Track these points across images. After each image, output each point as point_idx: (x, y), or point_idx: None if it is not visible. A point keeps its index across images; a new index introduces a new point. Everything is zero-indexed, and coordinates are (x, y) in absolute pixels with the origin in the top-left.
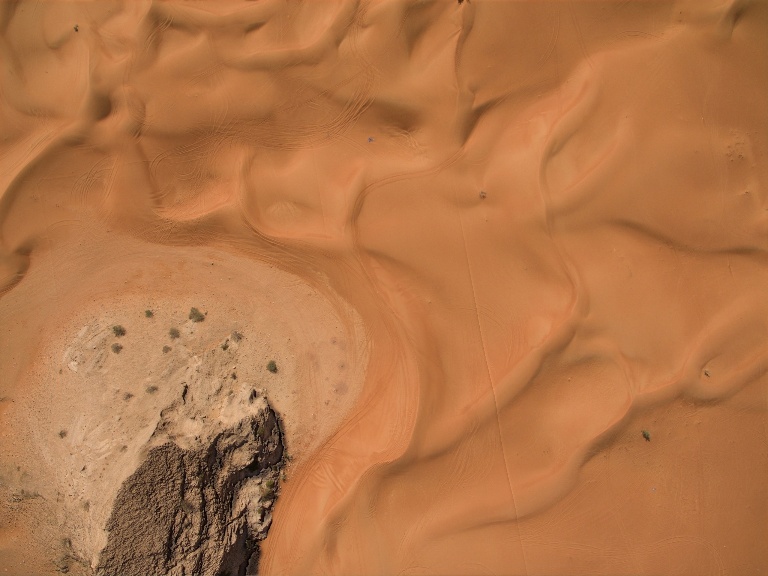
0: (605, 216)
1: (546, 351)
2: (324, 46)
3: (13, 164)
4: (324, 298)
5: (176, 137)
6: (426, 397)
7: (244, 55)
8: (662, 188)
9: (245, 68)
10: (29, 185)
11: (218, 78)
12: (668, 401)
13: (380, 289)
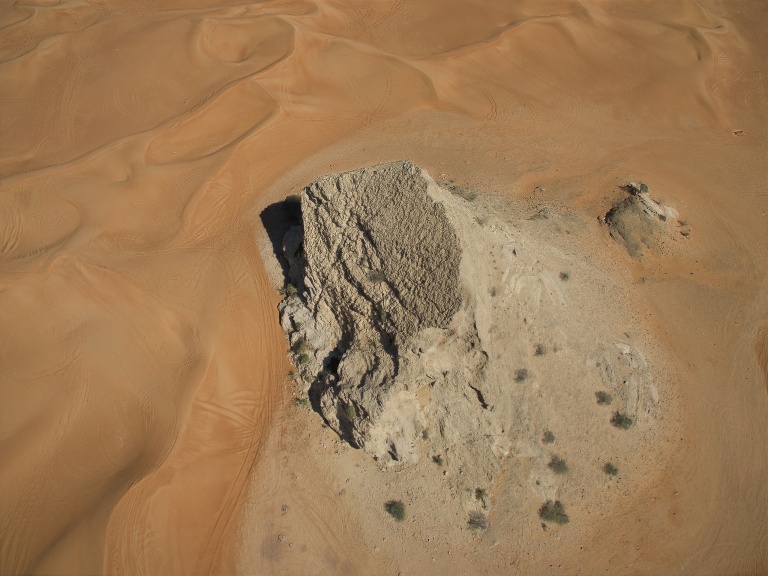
0: None
1: None
2: None
3: None
4: None
5: None
6: None
7: None
8: None
9: None
10: None
11: None
12: None
13: None
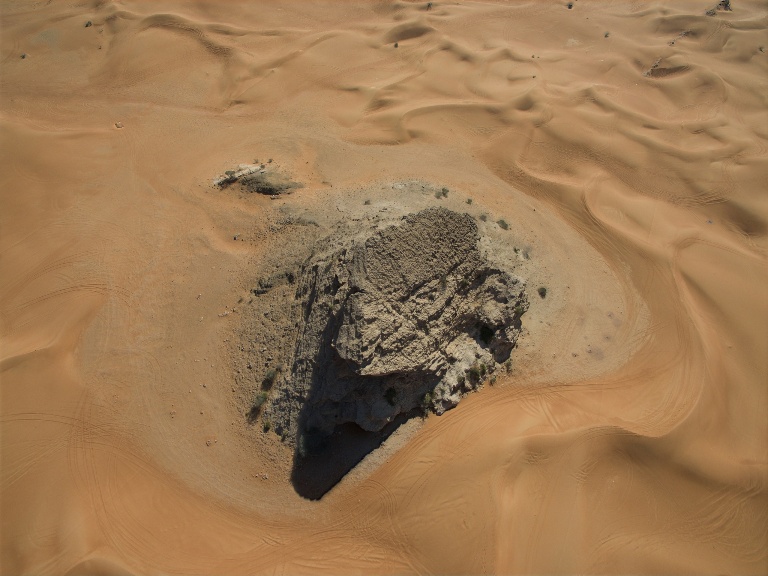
0: None
1: None
2: (701, 156)
3: (444, 102)
4: (618, 281)
5: (561, 140)
6: (704, 408)
7: (636, 133)
8: None
9: (633, 138)
10: (446, 113)
11: (609, 134)
12: None
13: (685, 300)
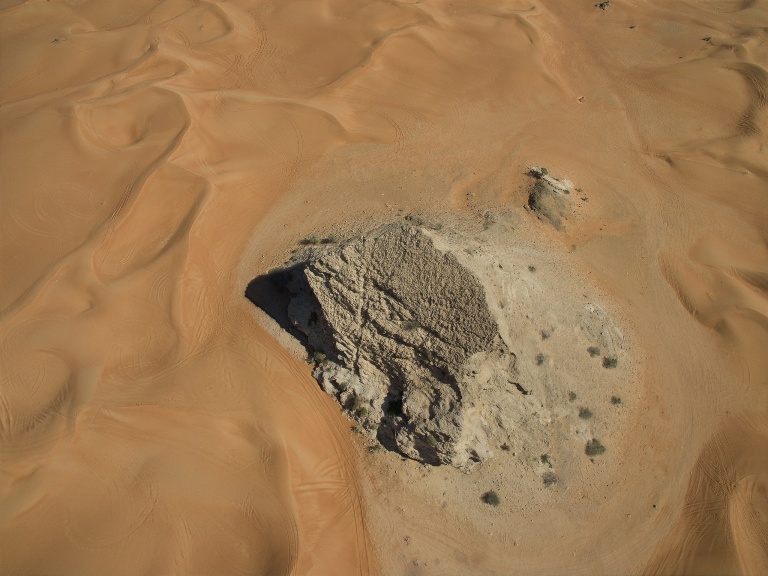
0: None
1: None
2: None
3: None
4: None
5: None
6: None
7: None
8: None
9: None
10: None
11: None
12: None
13: None
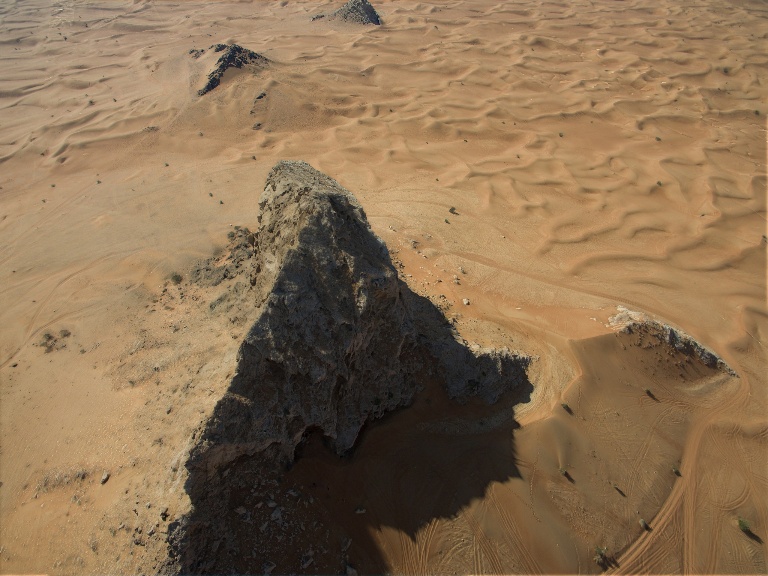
0: (420, 1)
1: (418, 6)
2: None
3: None
4: None
5: (344, 3)
6: None
7: None
8: (428, 0)
9: None
10: None
11: None
12: (442, 8)
13: (386, 6)
